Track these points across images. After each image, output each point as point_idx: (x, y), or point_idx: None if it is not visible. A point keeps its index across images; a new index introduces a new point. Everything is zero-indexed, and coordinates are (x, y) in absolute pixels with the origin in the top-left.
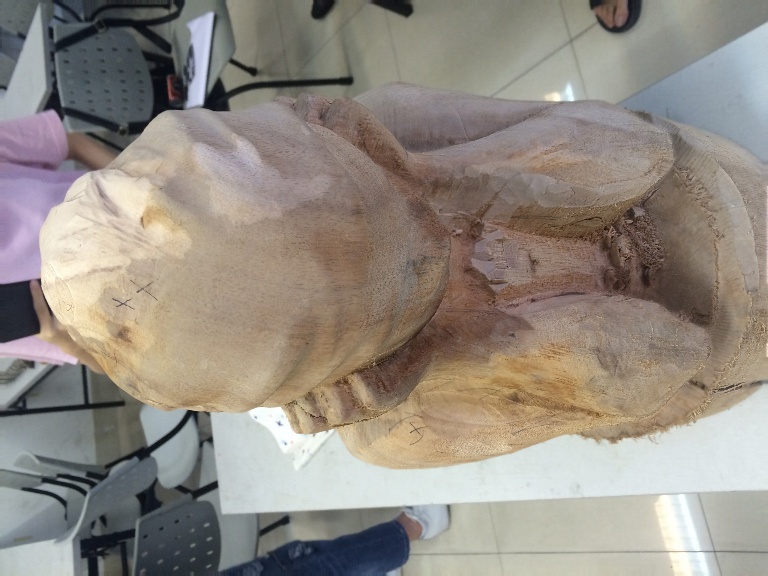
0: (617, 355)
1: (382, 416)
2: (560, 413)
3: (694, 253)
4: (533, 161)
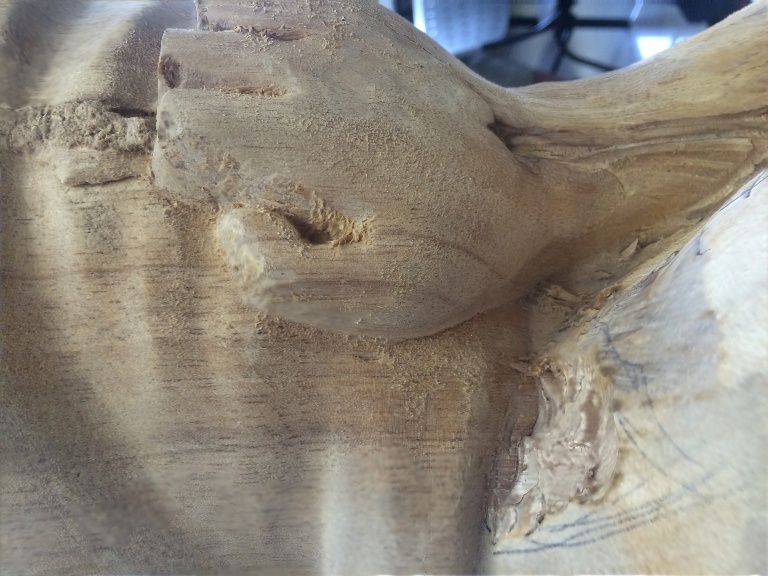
0: None
1: (659, 291)
2: None
3: None
4: None
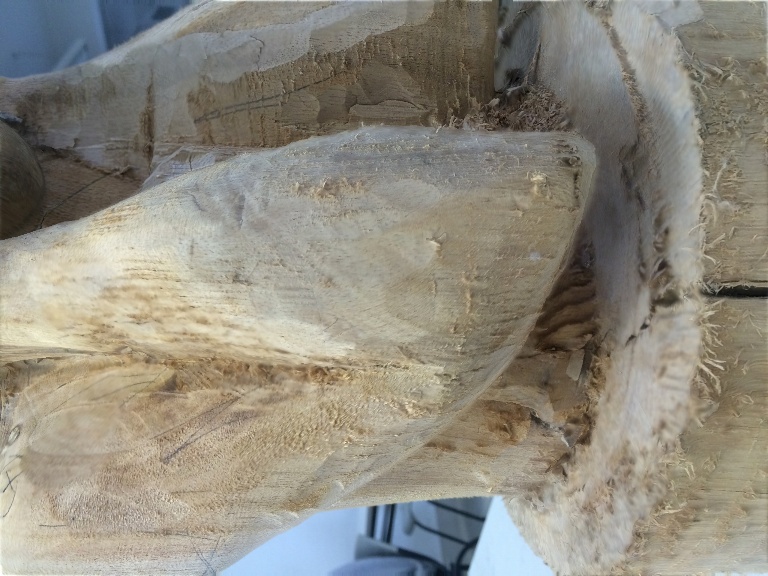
0: (241, 186)
1: None
2: (248, 392)
3: (591, 68)
4: (177, 24)
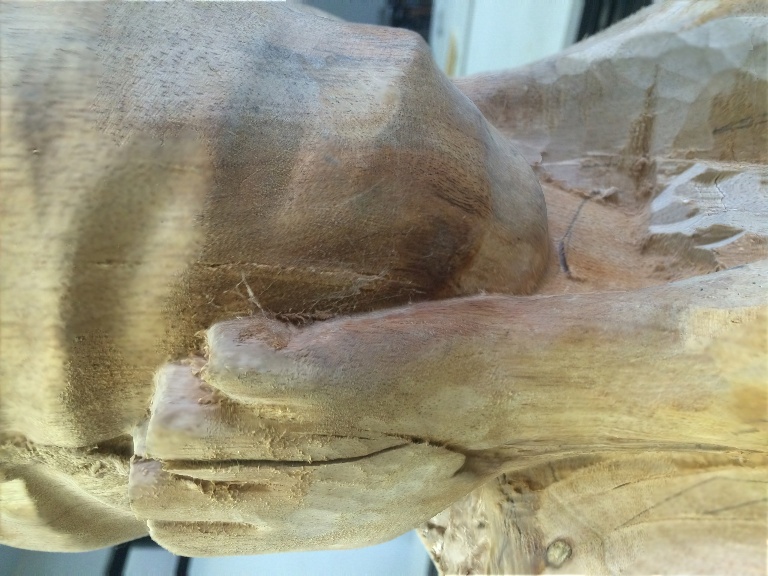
0: None
1: None
2: None
3: None
4: (695, 7)
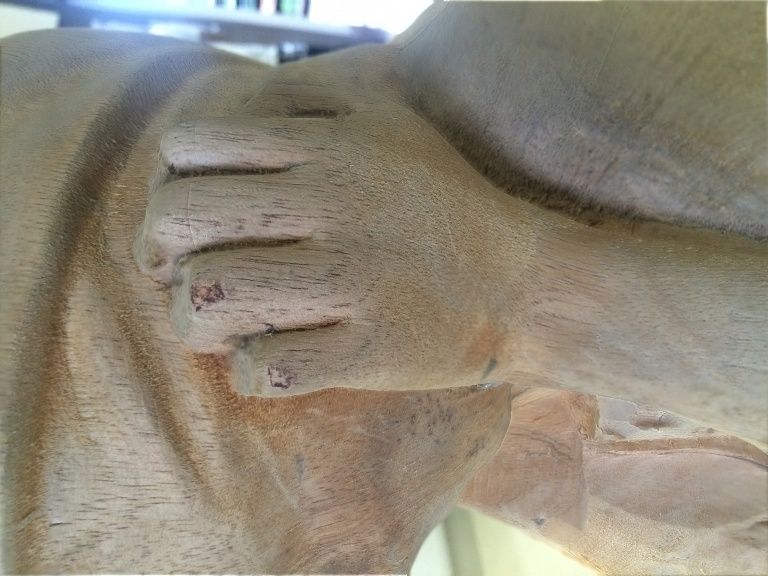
0: None
1: None
2: None
3: None
4: None
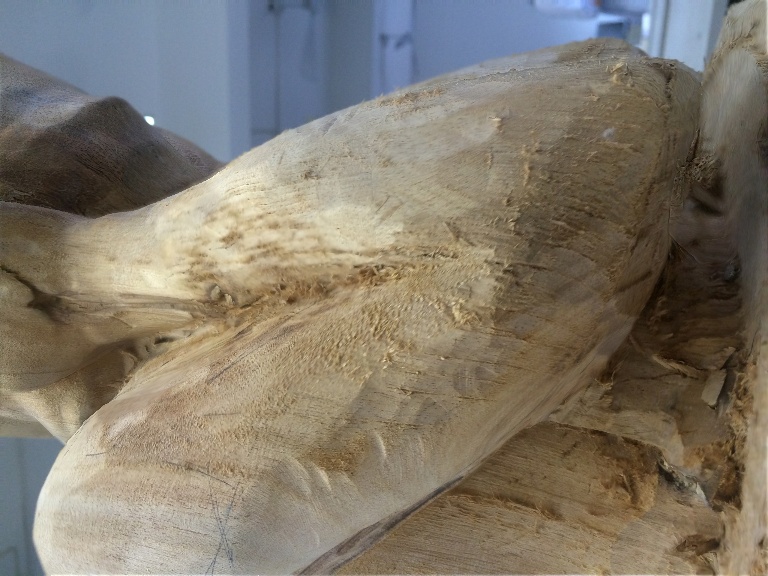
0: None
1: None
2: (303, 310)
3: None
4: None
